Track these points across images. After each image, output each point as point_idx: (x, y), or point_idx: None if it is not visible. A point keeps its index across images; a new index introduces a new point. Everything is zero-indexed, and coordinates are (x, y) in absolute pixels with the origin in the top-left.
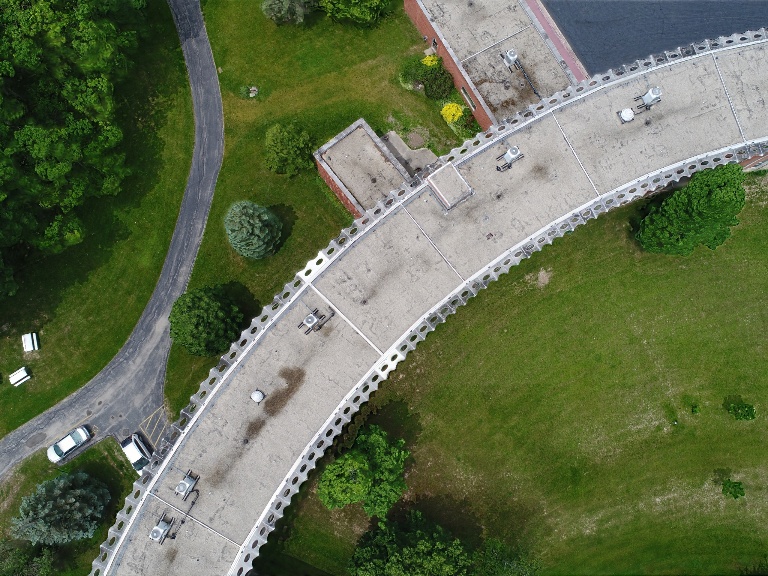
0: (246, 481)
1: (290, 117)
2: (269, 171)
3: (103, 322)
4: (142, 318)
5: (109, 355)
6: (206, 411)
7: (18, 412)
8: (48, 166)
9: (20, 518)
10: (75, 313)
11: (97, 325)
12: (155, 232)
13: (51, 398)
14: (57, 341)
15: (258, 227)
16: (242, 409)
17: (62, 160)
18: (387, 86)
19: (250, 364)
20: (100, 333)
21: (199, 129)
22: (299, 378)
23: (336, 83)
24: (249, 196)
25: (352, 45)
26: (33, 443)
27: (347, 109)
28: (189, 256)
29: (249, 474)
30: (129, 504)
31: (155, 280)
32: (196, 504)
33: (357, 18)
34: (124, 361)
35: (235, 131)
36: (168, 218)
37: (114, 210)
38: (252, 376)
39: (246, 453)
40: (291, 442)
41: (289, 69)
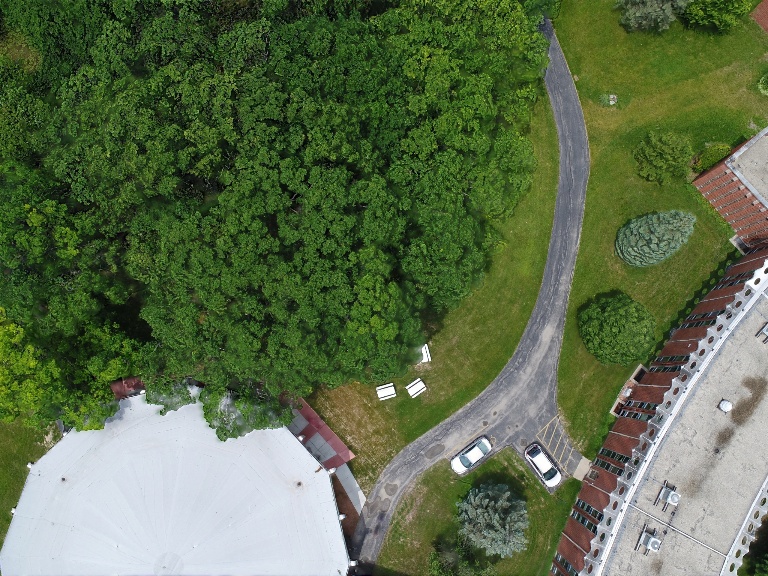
0: (723, 491)
1: (652, 124)
2: (637, 179)
3: (490, 332)
4: (528, 328)
5: (499, 365)
6: (675, 421)
7: (415, 424)
8: (521, 178)
9: (498, 531)
10: (462, 323)
11: (484, 335)
12: (532, 241)
13: (447, 409)
14: (447, 352)
15: (687, 236)
16: (709, 419)
17: (526, 172)
18: (745, 92)
19: (712, 374)
20: (488, 343)
21: (562, 137)
22: (762, 387)
23: (694, 90)
24: (620, 204)
25: (705, 52)
26: (432, 455)
27: (708, 116)
28: (568, 265)
29: (725, 484)
30: (608, 516)
31: (537, 289)
32: (676, 514)
33: (724, 25)
34: (515, 371)
35: (599, 139)
36: (543, 227)
37: (489, 220)
38: (716, 386)
39: (719, 463)
40: (763, 451)
41: (645, 76)
